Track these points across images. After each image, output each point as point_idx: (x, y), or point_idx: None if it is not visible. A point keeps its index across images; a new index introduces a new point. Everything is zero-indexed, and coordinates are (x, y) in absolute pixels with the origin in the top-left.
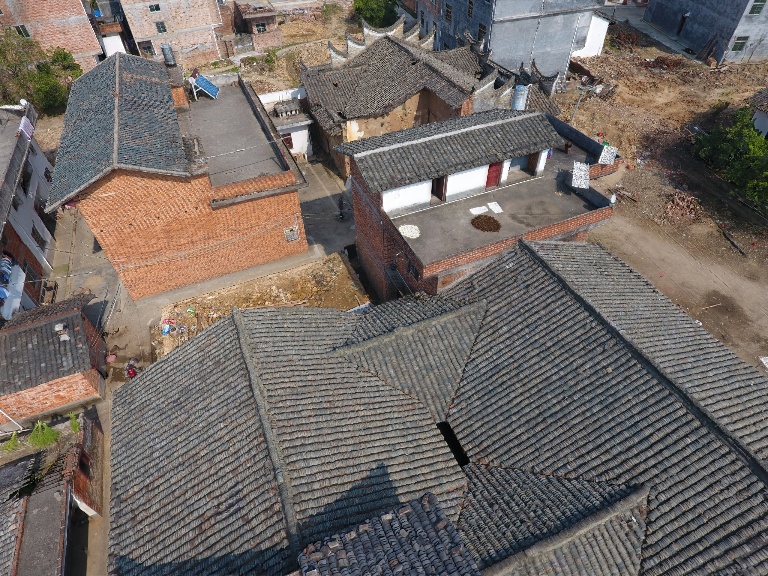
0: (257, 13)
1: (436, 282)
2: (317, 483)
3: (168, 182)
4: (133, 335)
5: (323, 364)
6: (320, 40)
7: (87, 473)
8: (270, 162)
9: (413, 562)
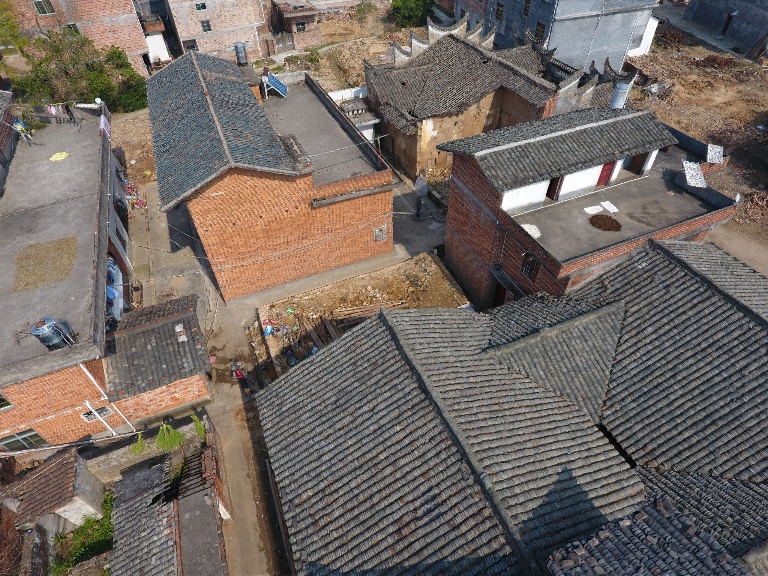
0: (298, 12)
1: (566, 282)
2: (517, 487)
3: (275, 181)
4: (229, 336)
5: (478, 366)
6: (359, 39)
7: (218, 476)
8: (360, 161)
9: (678, 570)
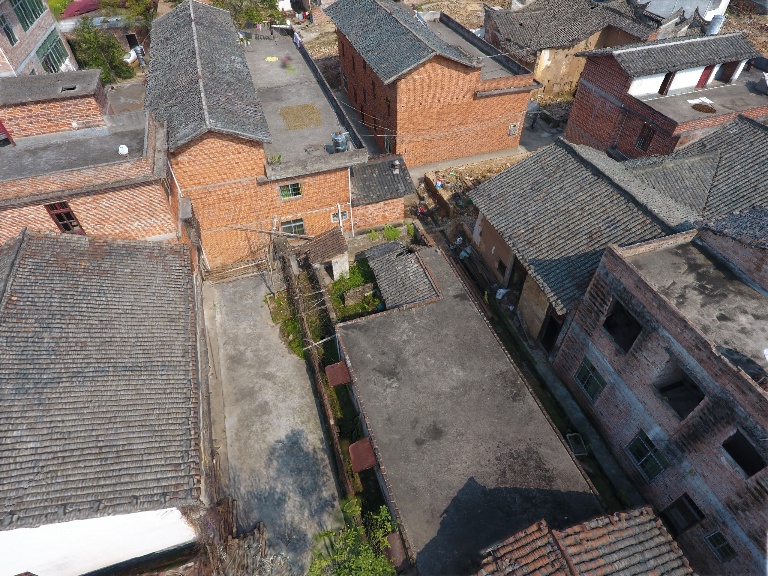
0: None
1: (676, 142)
2: None
3: (456, 72)
4: None
5: None
6: (453, 0)
7: None
8: (503, 71)
9: None
